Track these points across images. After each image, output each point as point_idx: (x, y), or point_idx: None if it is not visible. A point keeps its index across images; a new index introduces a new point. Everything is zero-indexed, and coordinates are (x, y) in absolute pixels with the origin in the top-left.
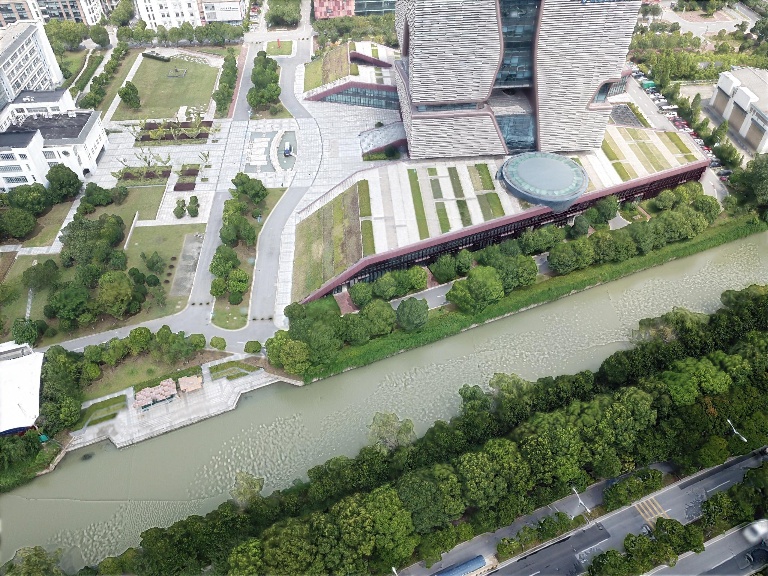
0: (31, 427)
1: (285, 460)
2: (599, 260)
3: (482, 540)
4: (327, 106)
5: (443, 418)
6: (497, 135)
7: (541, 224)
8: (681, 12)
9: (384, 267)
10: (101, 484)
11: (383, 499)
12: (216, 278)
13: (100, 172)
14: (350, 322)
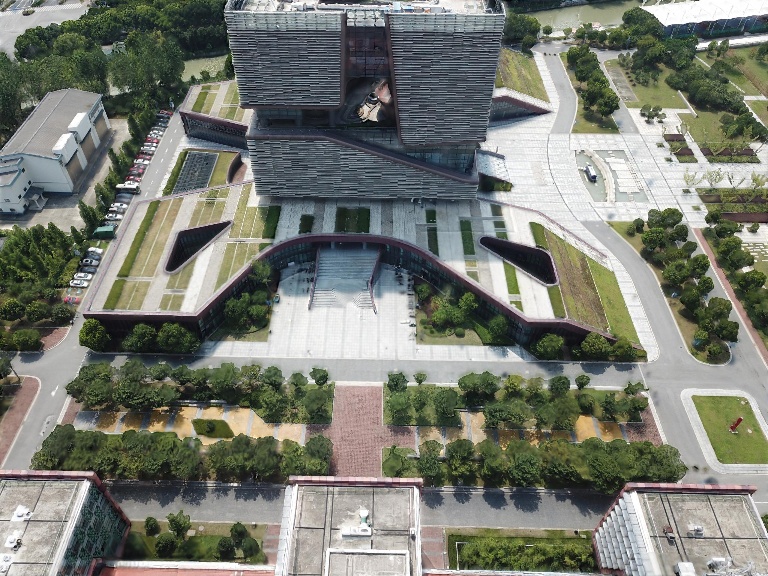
0: None
1: None
2: None
3: None
4: None
5: None
6: None
7: None
8: None
9: None
10: None
11: None
12: None
13: None
14: None
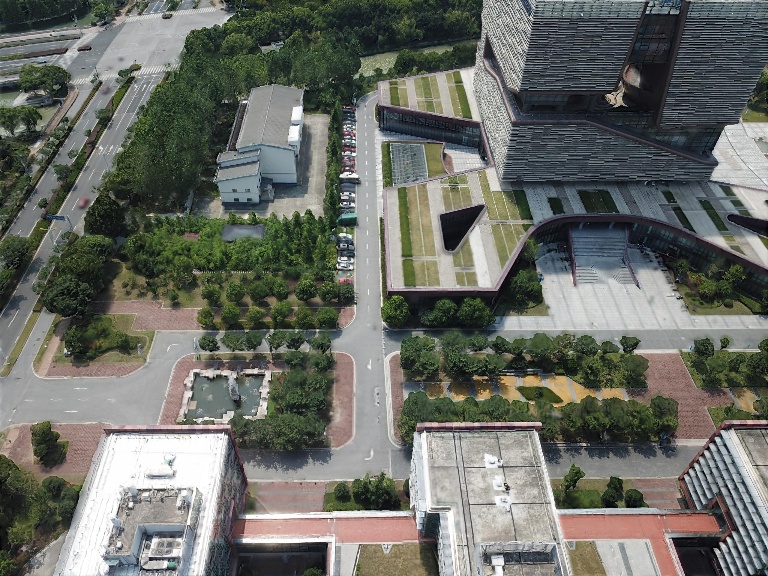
0: None
1: None
2: None
3: None
4: None
5: None
6: None
7: None
8: None
9: None
10: None
11: None
12: None
13: None
14: None
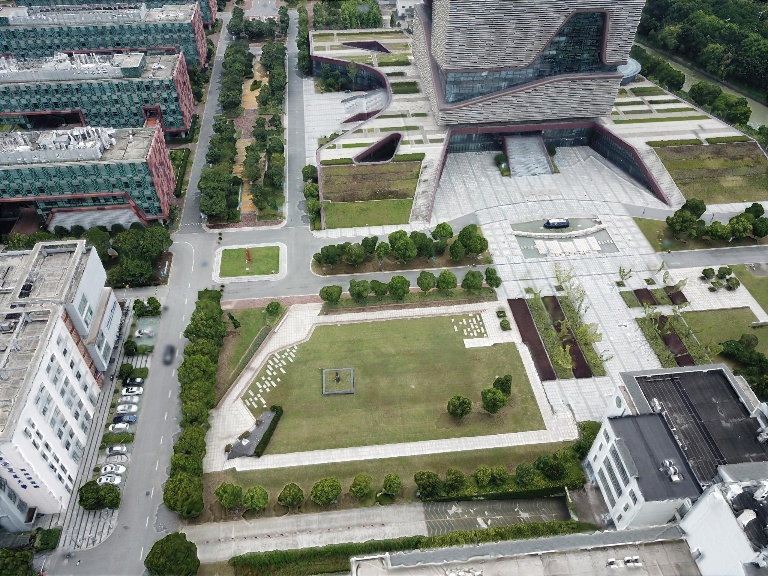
0: None
1: None
2: None
3: None
4: (444, 203)
5: None
6: None
7: None
8: (226, 9)
9: None
10: None
11: None
12: None
13: None
14: None
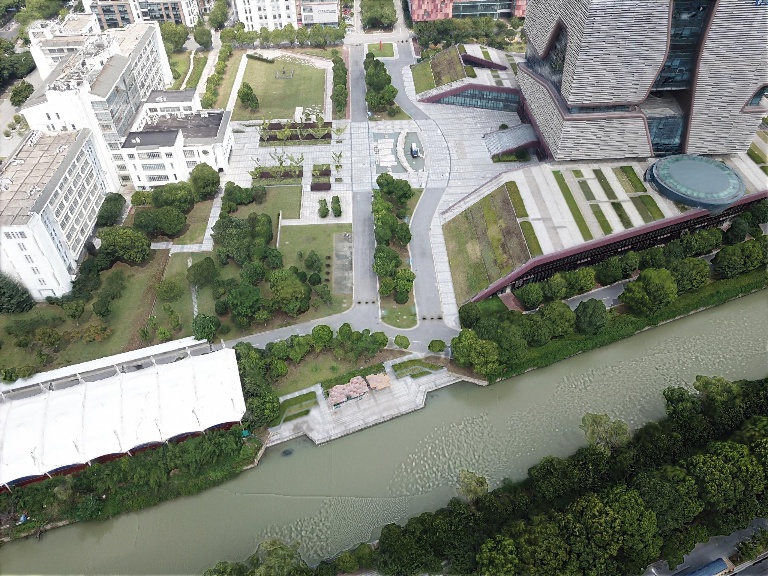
0: (237, 422)
1: (479, 459)
2: (766, 264)
3: (711, 543)
4: (443, 108)
5: (637, 420)
6: (646, 137)
7: (695, 227)
8: None
9: (548, 268)
10: (303, 480)
11: (629, 499)
12: (377, 277)
13: (232, 171)
14: (533, 322)
